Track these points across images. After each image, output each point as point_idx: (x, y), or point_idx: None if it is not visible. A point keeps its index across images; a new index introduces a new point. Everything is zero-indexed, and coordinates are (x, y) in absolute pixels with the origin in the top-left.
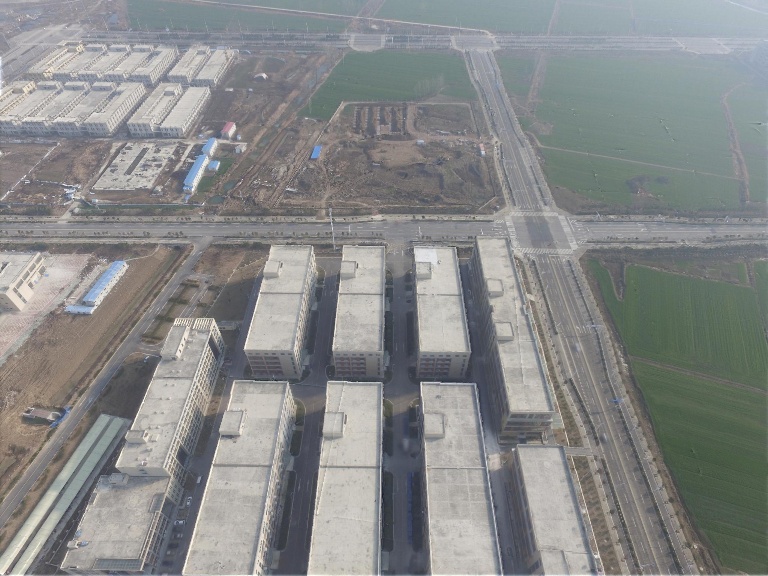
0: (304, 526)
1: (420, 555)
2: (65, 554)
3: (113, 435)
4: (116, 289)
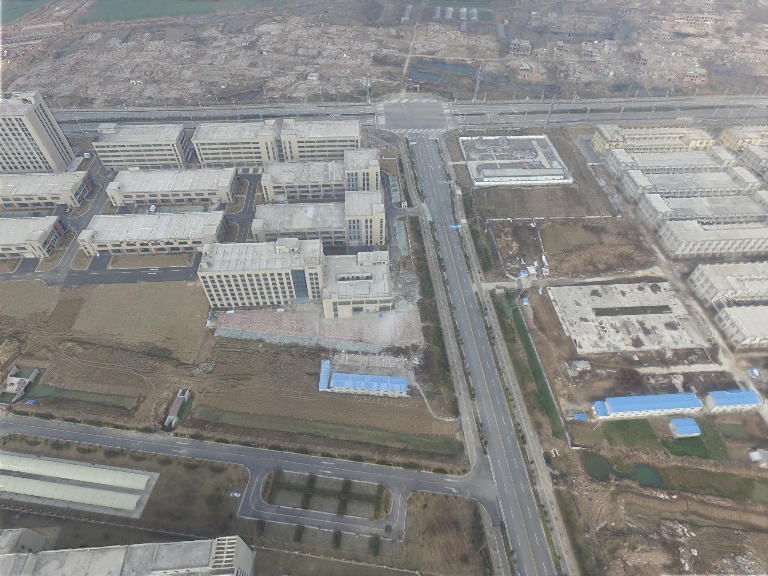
0: None
1: None
2: None
3: (116, 505)
4: (364, 400)
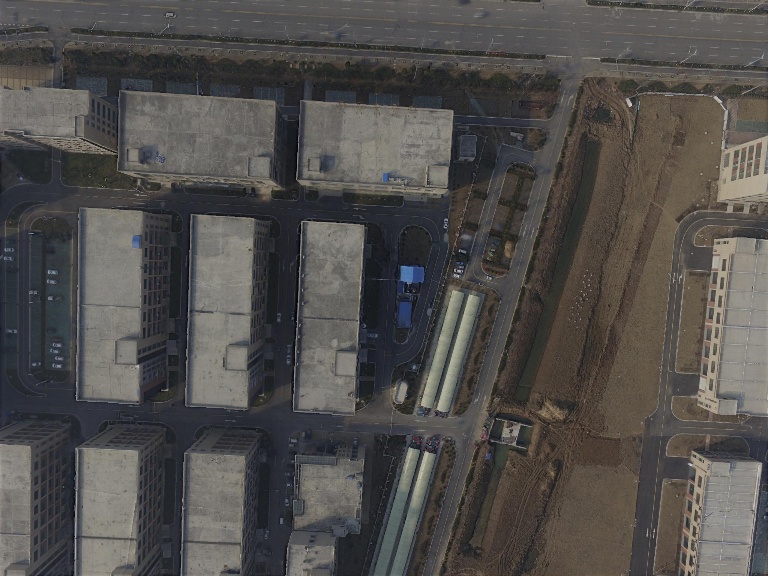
0: (179, 477)
1: (73, 451)
2: (383, 464)
3: (378, 567)
4: None
